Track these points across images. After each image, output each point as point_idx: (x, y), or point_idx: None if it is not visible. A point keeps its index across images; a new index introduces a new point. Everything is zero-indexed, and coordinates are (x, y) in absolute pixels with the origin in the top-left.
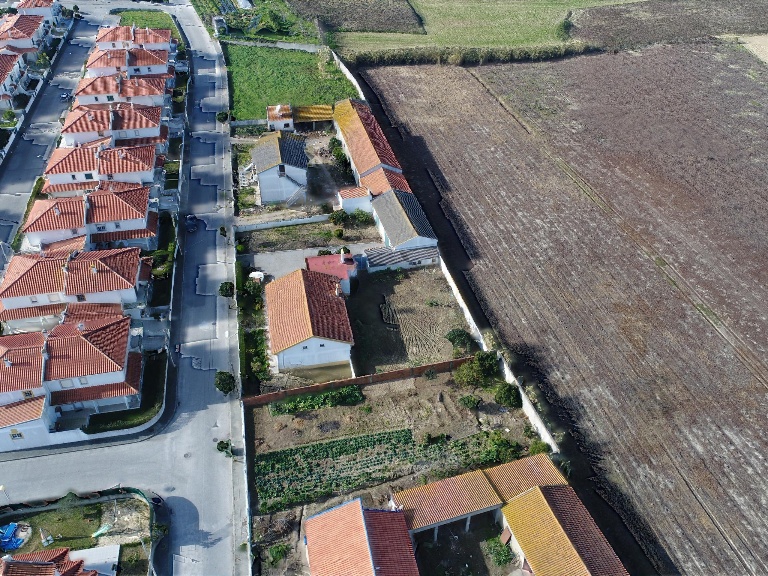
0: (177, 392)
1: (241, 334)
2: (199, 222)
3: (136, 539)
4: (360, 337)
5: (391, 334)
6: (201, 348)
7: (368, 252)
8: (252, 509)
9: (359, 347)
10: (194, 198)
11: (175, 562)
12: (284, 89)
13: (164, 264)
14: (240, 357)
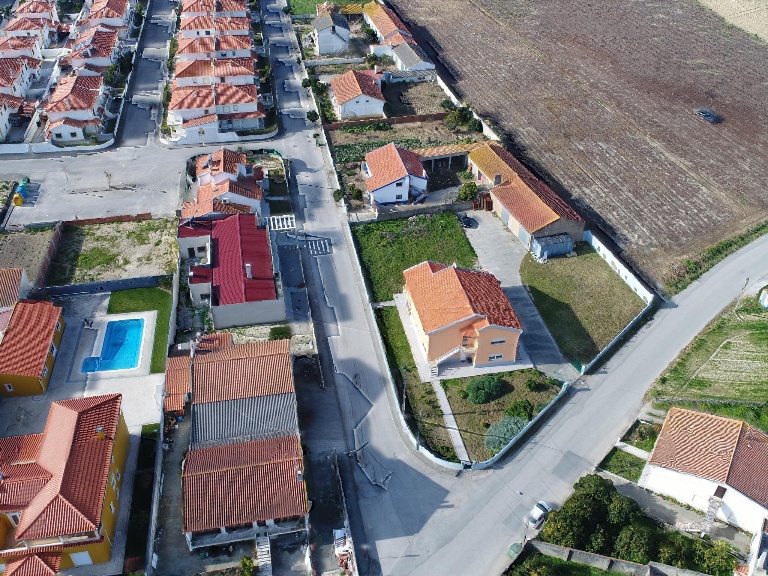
0: (284, 126)
1: (318, 103)
2: (280, 62)
3: (275, 169)
4: (388, 107)
5: (407, 107)
6: (294, 111)
7: (391, 71)
8: (334, 162)
9: (388, 110)
10: (274, 52)
11: (297, 177)
12: (325, 0)
13: (263, 77)
14: (319, 111)
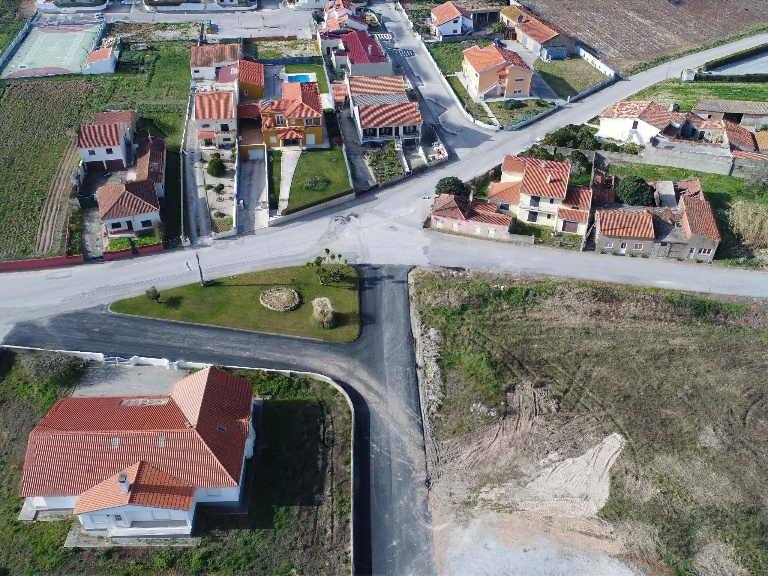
0: (371, 1)
1: None
2: None
3: None
4: None
5: None
6: None
7: None
8: None
9: None
10: None
11: (385, 24)
12: None
13: None
14: None
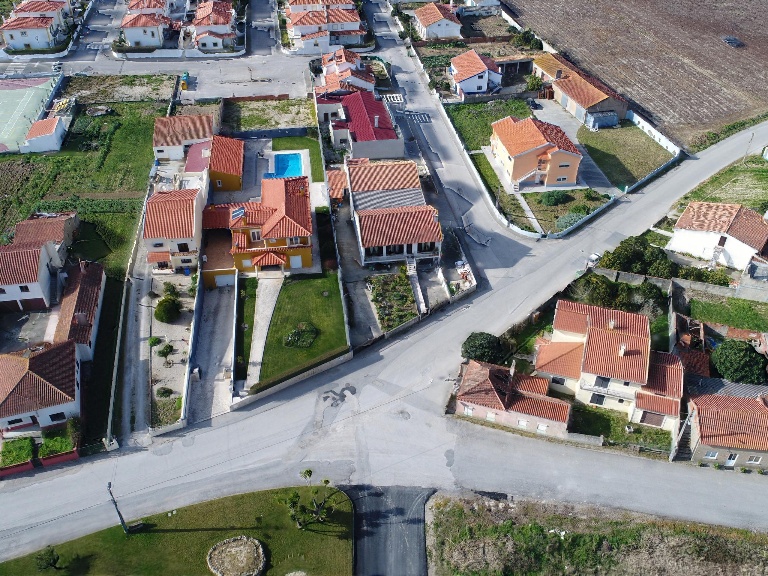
0: (379, 43)
1: (405, 28)
2: (368, 0)
3: None
4: (463, 32)
5: (478, 32)
6: (385, 34)
7: None
8: None
9: (463, 33)
10: None
11: (396, 76)
12: None
13: None
14: None
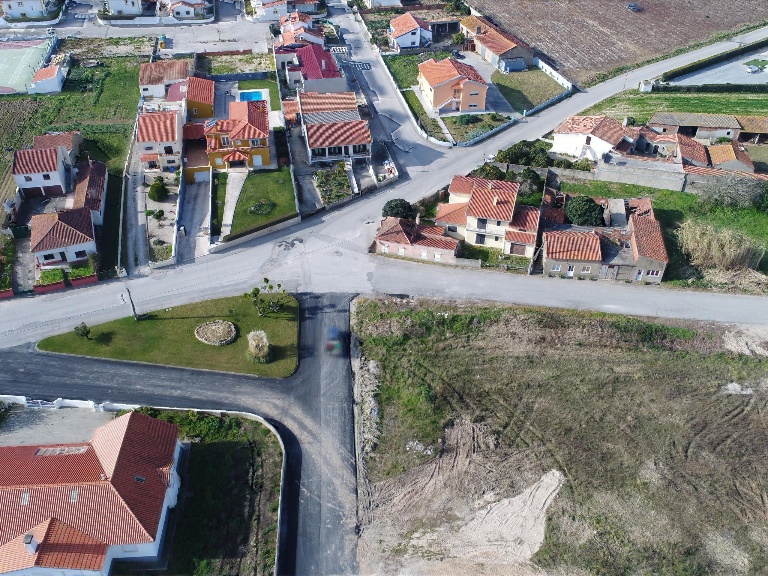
0: (331, 12)
1: None
2: None
3: None
4: (404, 2)
5: (417, 2)
6: (336, 4)
7: None
8: (368, 29)
9: (404, 3)
10: None
11: (344, 36)
12: None
13: None
14: None
